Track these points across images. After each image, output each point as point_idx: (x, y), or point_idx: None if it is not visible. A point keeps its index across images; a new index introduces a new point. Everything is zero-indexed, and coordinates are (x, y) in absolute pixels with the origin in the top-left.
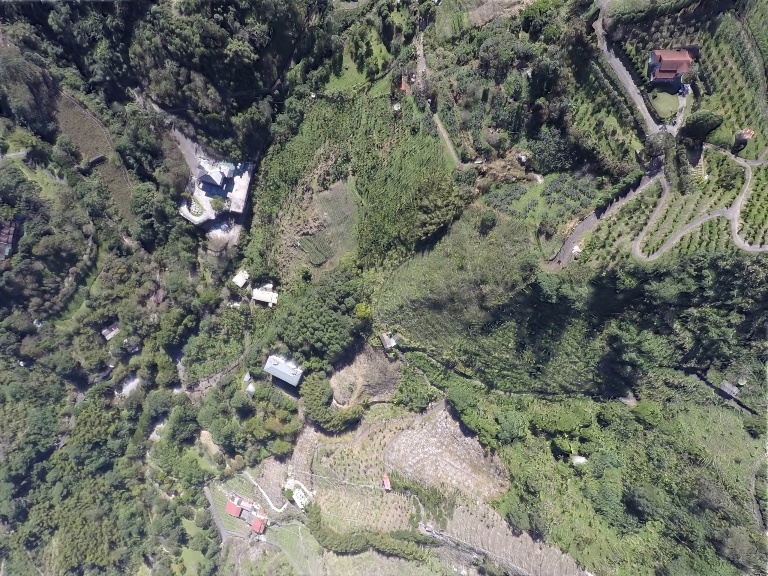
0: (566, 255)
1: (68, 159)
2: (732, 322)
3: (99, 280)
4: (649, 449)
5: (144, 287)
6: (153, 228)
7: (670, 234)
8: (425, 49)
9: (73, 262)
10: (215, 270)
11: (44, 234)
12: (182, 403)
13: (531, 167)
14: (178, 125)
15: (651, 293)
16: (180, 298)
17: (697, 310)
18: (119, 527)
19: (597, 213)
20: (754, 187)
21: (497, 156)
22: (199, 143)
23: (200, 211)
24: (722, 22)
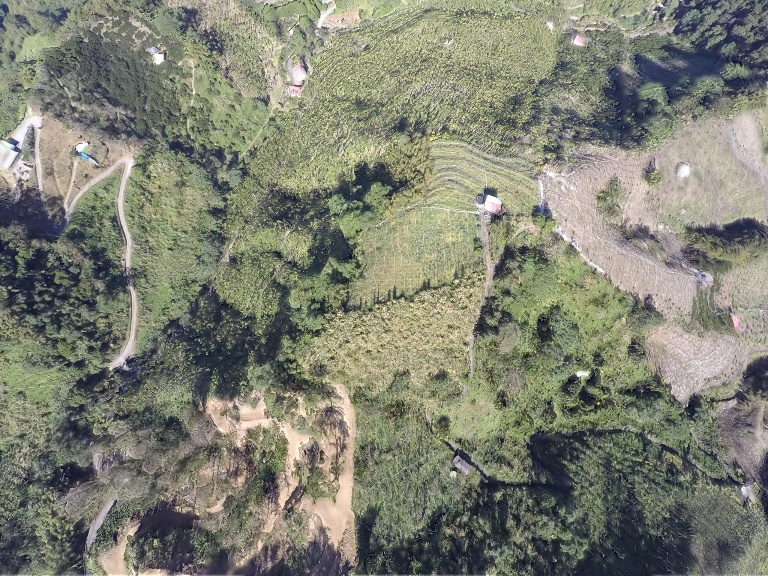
0: None
1: None
2: (494, 568)
3: None
4: None
5: None
6: None
7: None
8: None
9: None
10: None
11: None
12: None
13: None
14: None
15: None
16: None
17: None
18: None
19: None
20: None
21: None
22: None
23: None
24: None
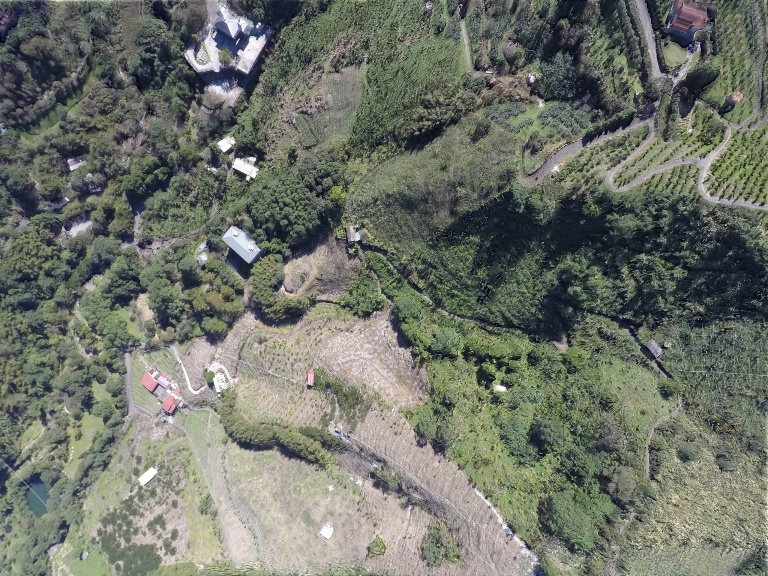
0: (545, 173)
1: None
2: (675, 276)
3: (81, 104)
4: (567, 390)
5: (126, 124)
6: (153, 66)
7: (644, 171)
8: None
9: (60, 76)
10: (203, 126)
11: (38, 34)
12: (129, 254)
13: (537, 89)
14: None
15: (611, 223)
16: (159, 145)
17: (647, 257)
18: (25, 370)
19: (584, 141)
20: (729, 146)
21: (508, 71)
22: None
23: (206, 60)
24: None
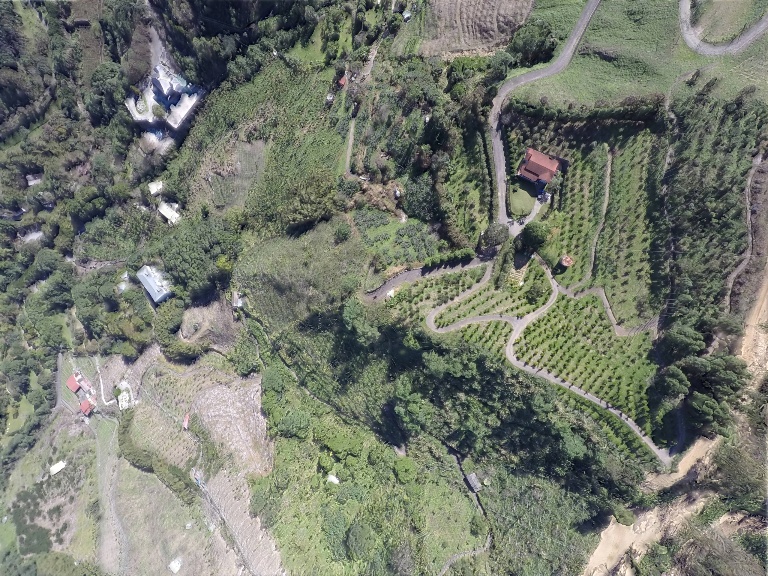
0: (382, 294)
1: (56, 9)
2: (489, 423)
3: (41, 129)
4: (389, 500)
5: (73, 153)
6: (102, 105)
7: (463, 317)
8: (376, 56)
9: (24, 102)
10: (136, 168)
11: (6, 65)
12: (64, 270)
13: (402, 204)
14: (155, 23)
15: None
16: (98, 178)
17: (466, 398)
18: None
19: (424, 270)
20: (550, 312)
21: (381, 180)
22: (166, 48)
23: (143, 109)
24: (593, 150)
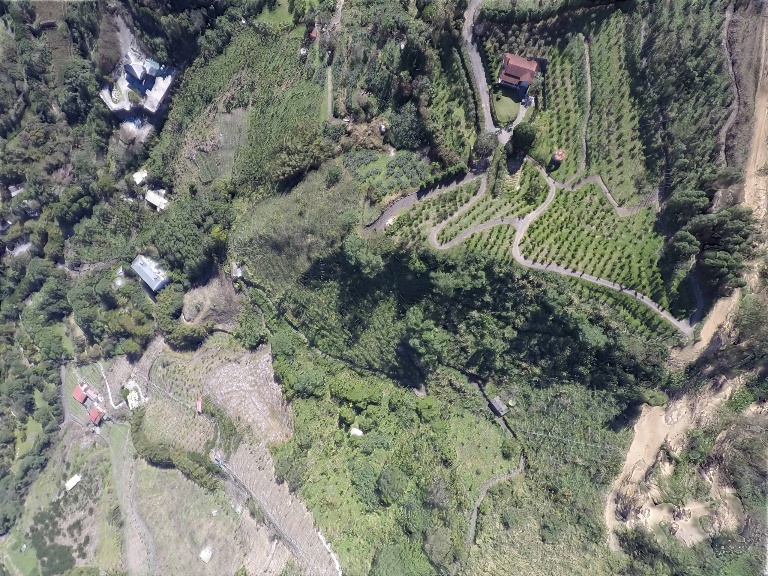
0: (381, 225)
1: (21, 14)
2: (506, 336)
3: (19, 137)
4: (416, 441)
5: (54, 156)
6: (77, 103)
7: (465, 229)
8: (344, 4)
9: None
10: (119, 160)
11: None
12: (57, 276)
13: (388, 138)
14: (121, 12)
15: (434, 280)
16: (81, 176)
17: (480, 315)
18: None
19: (419, 194)
20: (550, 208)
21: (364, 119)
22: (135, 35)
23: (119, 99)
24: (569, 43)
